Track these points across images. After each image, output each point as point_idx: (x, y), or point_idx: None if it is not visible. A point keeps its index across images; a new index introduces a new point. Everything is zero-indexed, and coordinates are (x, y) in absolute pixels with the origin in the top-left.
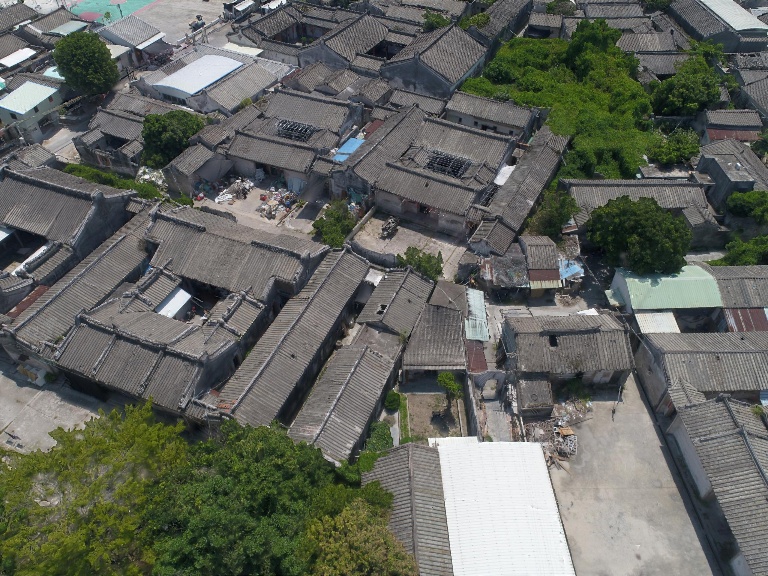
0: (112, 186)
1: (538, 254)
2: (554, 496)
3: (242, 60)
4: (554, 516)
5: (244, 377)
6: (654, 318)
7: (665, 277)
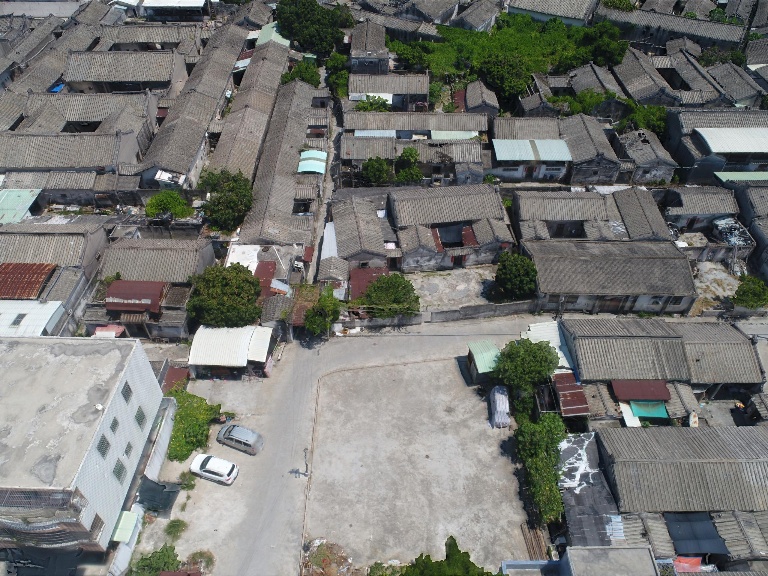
0: None
1: None
2: (181, 6)
3: None
4: None
5: None
6: None
7: (276, 29)
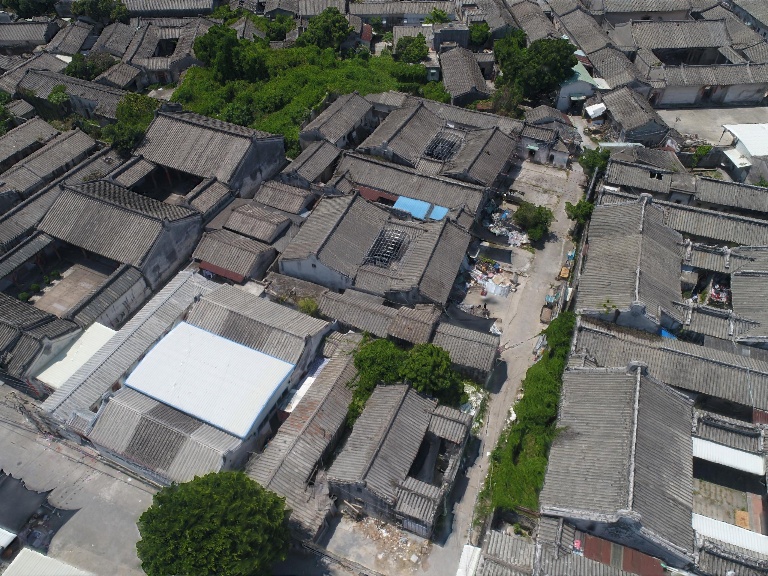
0: (524, 435)
1: (554, 114)
2: None
3: (144, 337)
4: (763, 124)
5: (765, 237)
6: (598, 83)
7: None
